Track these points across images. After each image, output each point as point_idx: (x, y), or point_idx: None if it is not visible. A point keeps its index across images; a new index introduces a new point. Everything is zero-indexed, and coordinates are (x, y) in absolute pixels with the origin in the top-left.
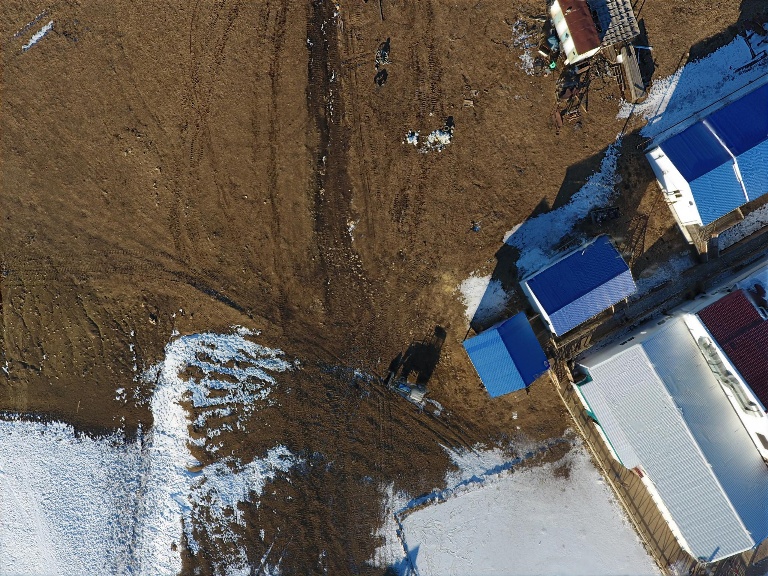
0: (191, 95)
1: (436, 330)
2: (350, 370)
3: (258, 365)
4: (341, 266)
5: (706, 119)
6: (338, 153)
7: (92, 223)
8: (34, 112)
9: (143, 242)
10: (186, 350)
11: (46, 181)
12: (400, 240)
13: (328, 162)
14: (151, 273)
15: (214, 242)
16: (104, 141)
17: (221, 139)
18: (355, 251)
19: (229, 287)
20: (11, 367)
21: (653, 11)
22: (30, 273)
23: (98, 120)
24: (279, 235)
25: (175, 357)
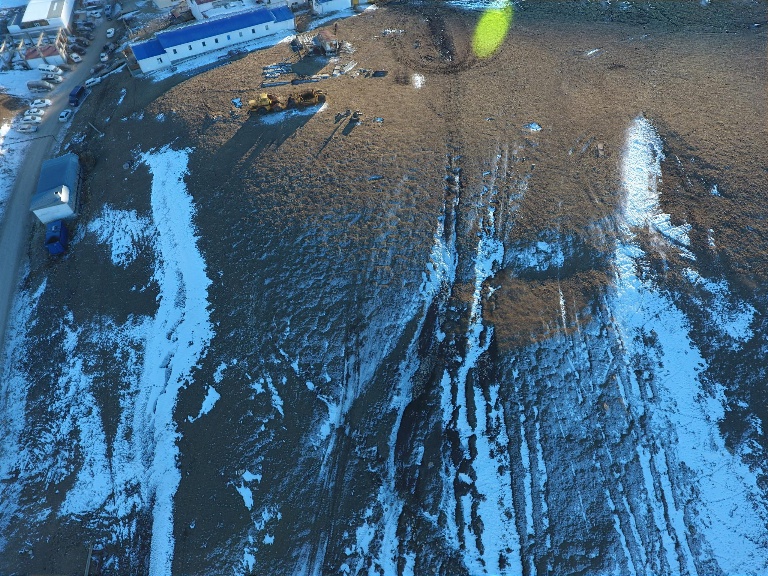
0: None
1: (389, 5)
2: (424, 2)
3: (464, 2)
4: None
5: None
6: None
7: None
8: None
9: None
10: (496, 5)
11: None
12: (406, 16)
13: None
14: None
15: None
16: None
17: None
18: None
19: None
20: (573, 1)
21: None
22: None
23: None
24: None
25: (501, 5)
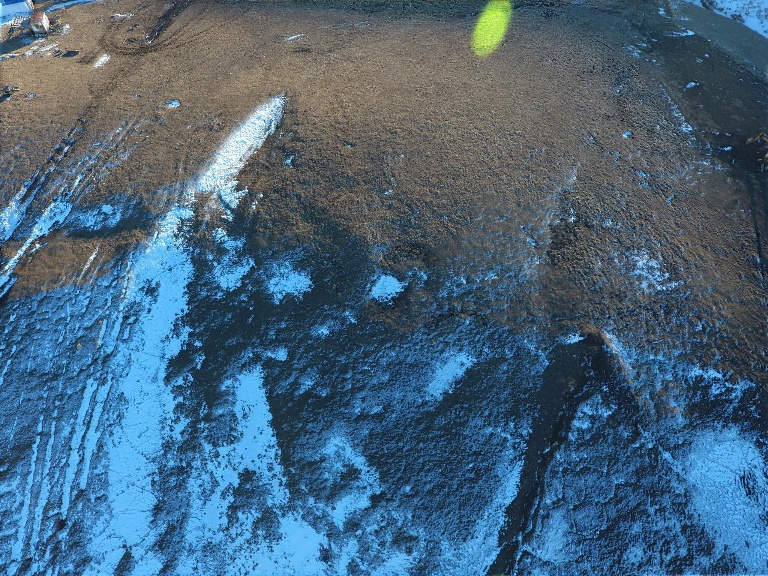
0: None
1: None
2: None
3: None
4: None
5: (3, 2)
6: None
7: None
8: None
9: None
10: None
11: None
12: None
13: None
14: None
15: None
16: None
17: None
18: None
19: None
20: None
21: (1, 34)
22: None
23: None
24: (205, 6)
25: None
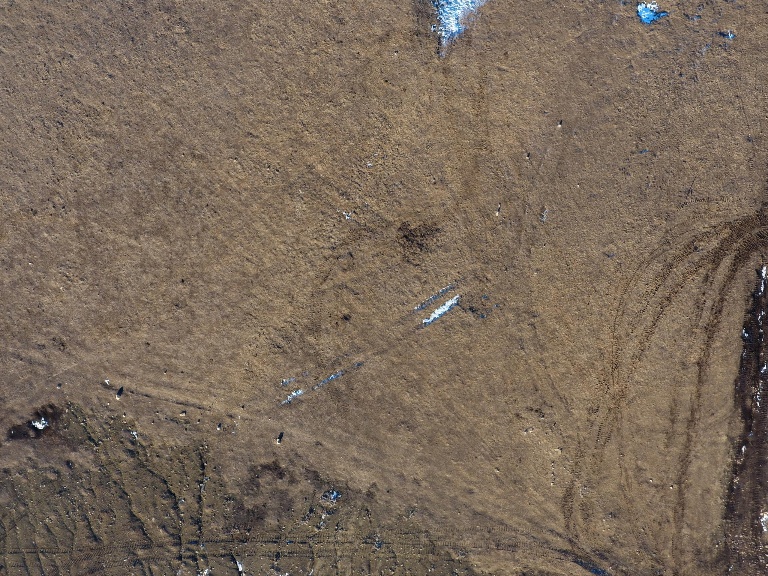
0: (607, 380)
1: None
2: None
3: None
4: (746, 554)
5: None
6: (761, 444)
7: (478, 499)
8: (430, 388)
9: (531, 519)
10: None
11: (435, 457)
12: None
13: (747, 452)
14: (535, 550)
15: (609, 523)
16: (503, 419)
17: (633, 424)
18: (765, 541)
19: (618, 567)
20: None
21: None
22: (405, 546)
23: (499, 398)
24: (682, 520)
25: None
